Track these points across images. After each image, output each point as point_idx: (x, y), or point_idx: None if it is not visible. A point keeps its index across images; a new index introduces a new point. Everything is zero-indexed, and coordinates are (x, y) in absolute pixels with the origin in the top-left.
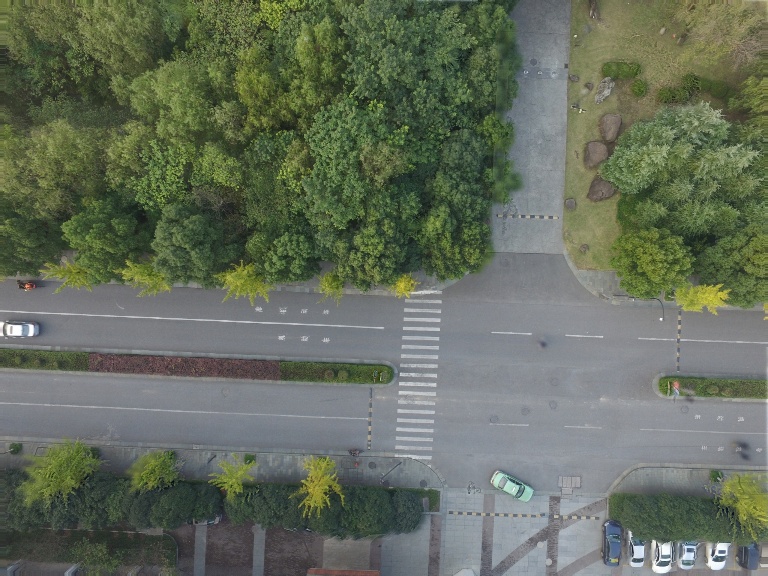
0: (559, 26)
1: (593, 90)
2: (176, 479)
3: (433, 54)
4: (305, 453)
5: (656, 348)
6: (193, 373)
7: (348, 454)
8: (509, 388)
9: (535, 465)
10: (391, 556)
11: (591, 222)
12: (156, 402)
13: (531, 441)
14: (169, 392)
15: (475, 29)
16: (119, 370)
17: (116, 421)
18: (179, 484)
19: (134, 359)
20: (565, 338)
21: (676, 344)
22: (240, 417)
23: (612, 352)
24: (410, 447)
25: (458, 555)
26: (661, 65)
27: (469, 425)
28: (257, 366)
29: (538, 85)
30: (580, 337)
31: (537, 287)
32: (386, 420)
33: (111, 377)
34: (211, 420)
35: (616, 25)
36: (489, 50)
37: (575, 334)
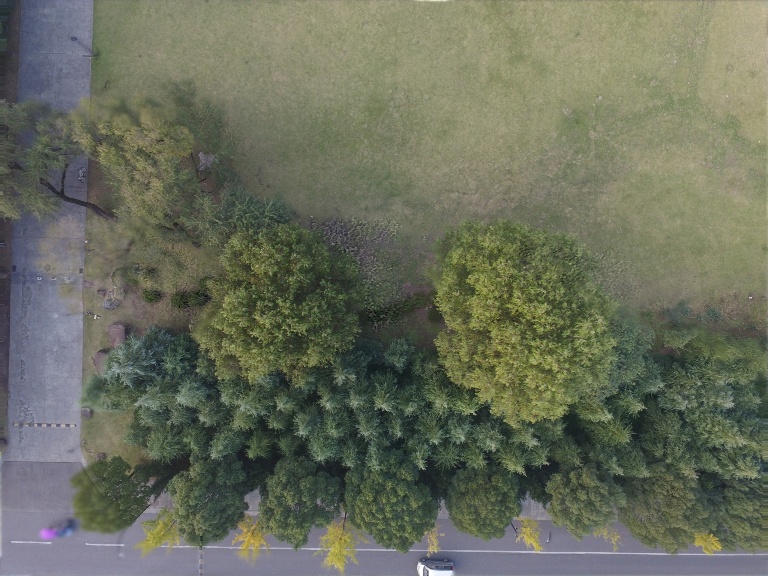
0: (73, 230)
1: (107, 296)
2: None
3: None
4: None
5: (178, 555)
6: None
7: None
8: None
9: None
10: None
11: (108, 430)
12: None
13: None
14: None
15: None
16: None
17: None
18: None
19: None
20: (85, 547)
21: (198, 551)
22: None
23: (132, 560)
24: None
25: None
26: (178, 268)
27: None
28: None
29: (52, 291)
30: (99, 546)
31: (55, 496)
32: None
33: None
34: None
35: (133, 227)
36: None
37: (94, 543)
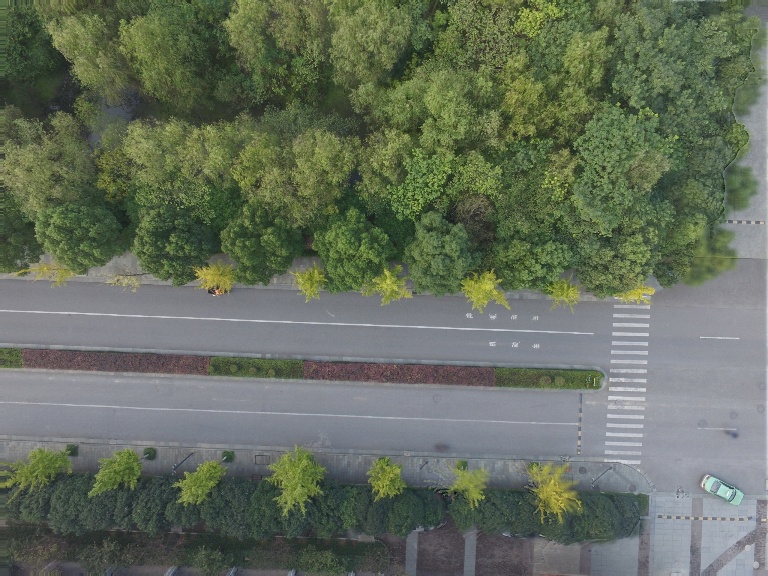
0: (764, 32)
1: None
2: (400, 486)
3: (693, 62)
4: (516, 459)
5: None
6: (408, 380)
7: (558, 459)
8: (717, 392)
9: (743, 469)
10: (601, 560)
11: None
12: (367, 409)
13: (739, 445)
14: (380, 399)
15: (733, 37)
16: (334, 377)
17: (327, 428)
18: (405, 491)
19: (349, 366)
20: None
21: None
22: (451, 423)
23: None
24: (619, 452)
25: (667, 559)
26: None
27: (678, 429)
28: (472, 372)
29: (744, 91)
30: None
31: (744, 292)
32: (596, 425)
33: (323, 384)
34: (422, 426)
35: None
36: (748, 58)
37: None
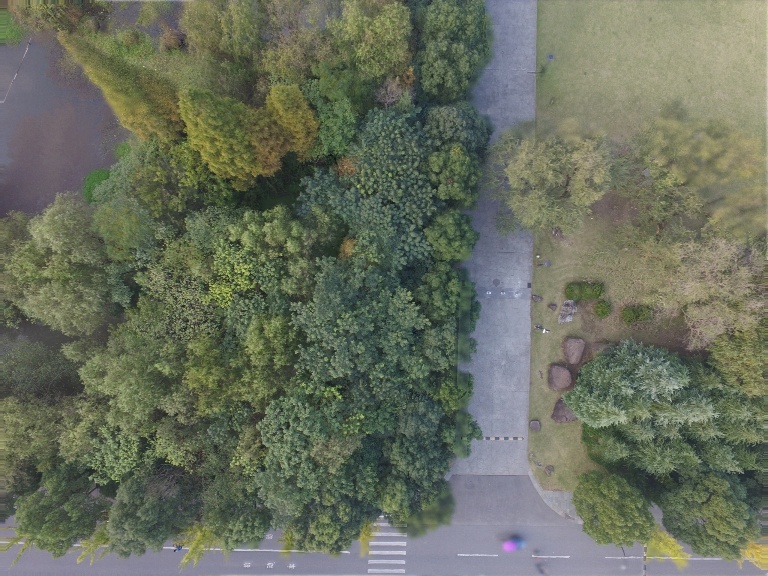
0: (522, 245)
1: (556, 310)
2: None
3: (386, 335)
4: None
5: (622, 566)
6: None
7: None
8: None
9: None
10: None
11: (556, 442)
12: None
13: None
14: None
15: (429, 308)
16: None
17: None
18: None
19: None
20: (531, 559)
21: (642, 562)
22: None
23: (578, 572)
24: None
25: None
26: (625, 282)
27: None
28: None
29: (501, 305)
30: (546, 558)
31: (503, 509)
32: None
33: None
34: None
35: (579, 242)
36: (443, 330)
37: (541, 555)
